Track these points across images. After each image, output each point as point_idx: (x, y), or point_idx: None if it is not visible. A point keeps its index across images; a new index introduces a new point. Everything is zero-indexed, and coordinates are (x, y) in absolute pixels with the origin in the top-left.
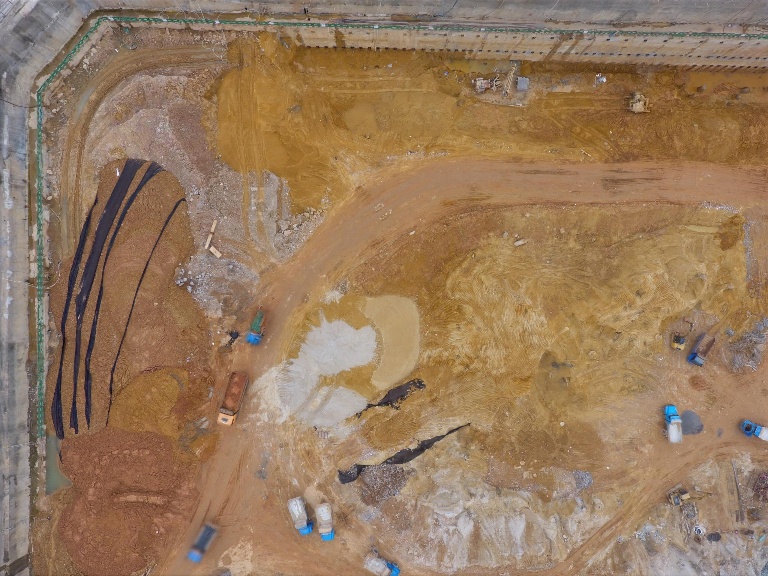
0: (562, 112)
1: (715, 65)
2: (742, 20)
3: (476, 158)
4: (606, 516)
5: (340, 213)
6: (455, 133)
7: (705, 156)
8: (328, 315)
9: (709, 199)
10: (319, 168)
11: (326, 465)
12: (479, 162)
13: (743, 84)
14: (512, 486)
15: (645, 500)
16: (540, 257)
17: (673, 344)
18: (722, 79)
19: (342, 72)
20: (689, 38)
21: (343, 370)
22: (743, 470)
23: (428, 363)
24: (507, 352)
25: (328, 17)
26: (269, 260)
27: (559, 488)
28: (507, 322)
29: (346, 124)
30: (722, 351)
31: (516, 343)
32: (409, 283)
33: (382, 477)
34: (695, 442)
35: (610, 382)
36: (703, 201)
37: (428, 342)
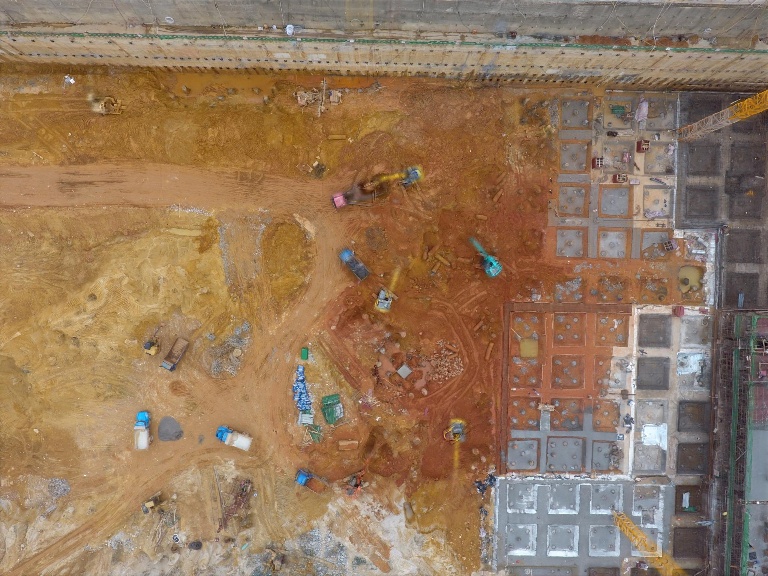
0: (30, 114)
1: (185, 66)
2: (138, 20)
3: None
4: (72, 525)
5: None
6: None
7: (166, 158)
8: None
9: (178, 202)
10: None
11: None
12: None
13: (231, 85)
14: None
15: (124, 508)
16: (11, 261)
17: None
18: (210, 80)
19: None
20: (91, 39)
21: None
22: (226, 477)
23: None
24: None
25: None
26: None
27: (30, 496)
28: None
29: None
30: (203, 356)
31: None
32: None
33: None
34: (174, 449)
35: (75, 388)
36: (172, 204)
37: None
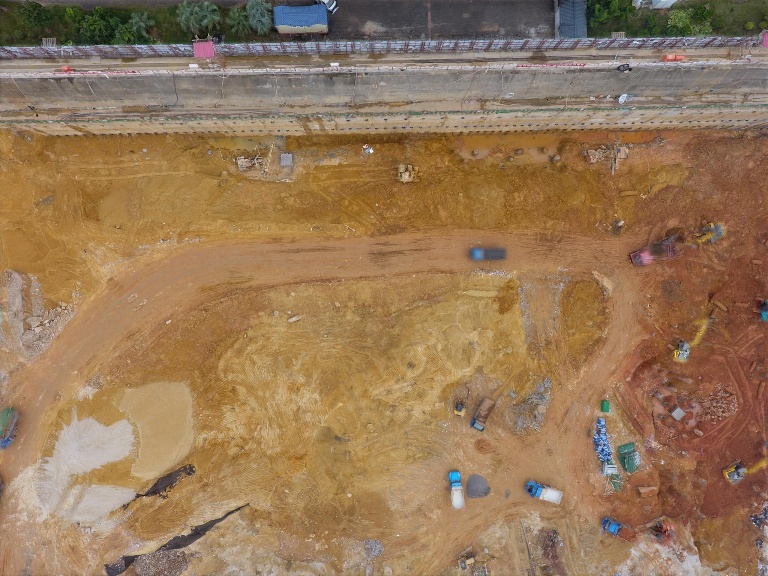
0: (331, 185)
1: (481, 131)
2: (476, 96)
3: (233, 241)
4: None
5: (91, 307)
6: (209, 218)
7: (472, 224)
8: (79, 413)
9: (481, 266)
10: (67, 262)
11: (92, 559)
12: (237, 245)
13: (517, 146)
14: (305, 558)
15: (437, 564)
16: (317, 331)
17: (454, 411)
18: (496, 141)
19: (96, 159)
20: (427, 116)
21: (94, 468)
22: (532, 529)
23: (203, 446)
24: (281, 431)
25: (57, 112)
26: (18, 360)
27: (349, 559)
28: (280, 401)
29: (98, 213)
30: (506, 414)
31: (290, 422)
32: (177, 369)
33: (157, 565)
34: (483, 505)
35: (391, 453)
36: (476, 268)
37: (202, 425)
